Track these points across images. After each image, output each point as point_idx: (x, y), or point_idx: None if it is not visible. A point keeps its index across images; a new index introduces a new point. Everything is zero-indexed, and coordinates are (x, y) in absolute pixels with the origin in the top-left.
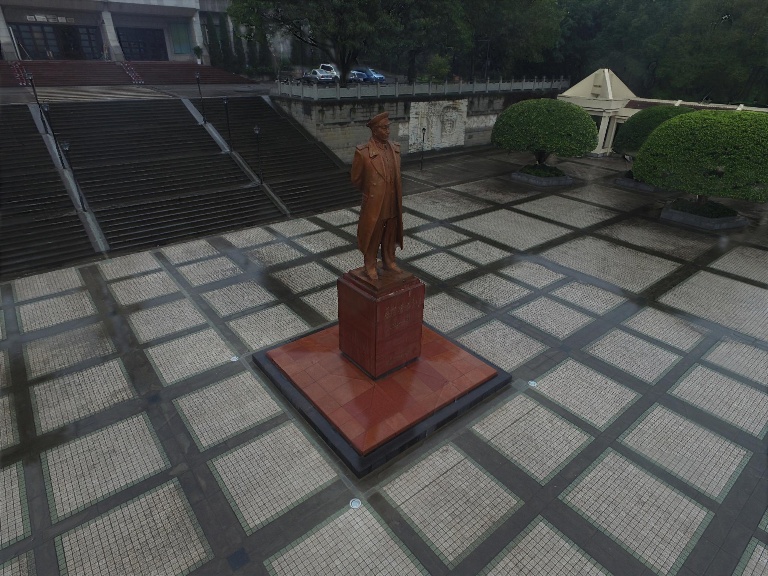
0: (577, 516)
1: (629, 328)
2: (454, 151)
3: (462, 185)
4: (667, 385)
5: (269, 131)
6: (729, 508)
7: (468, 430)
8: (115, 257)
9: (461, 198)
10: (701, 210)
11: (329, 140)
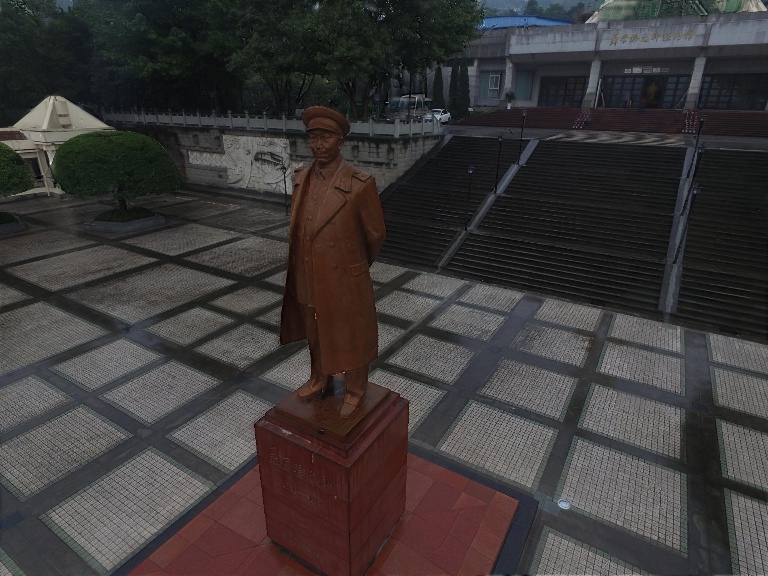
0: None
1: None
2: None
3: None
4: None
5: None
6: None
7: None
8: (440, 274)
9: None
10: None
11: None
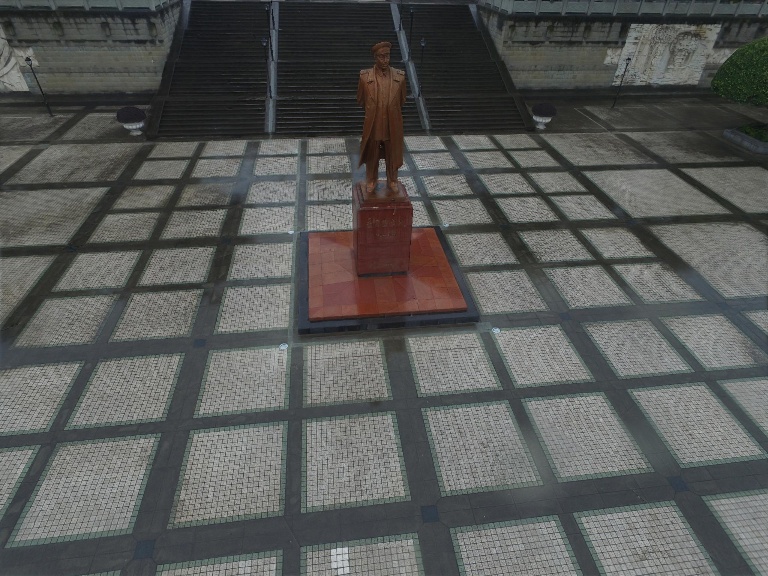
0: (422, 426)
1: (664, 325)
2: (678, 91)
3: (644, 133)
4: (636, 385)
5: (457, 44)
6: (563, 489)
7: (403, 339)
8: (275, 139)
9: (625, 147)
10: None
11: (515, 60)
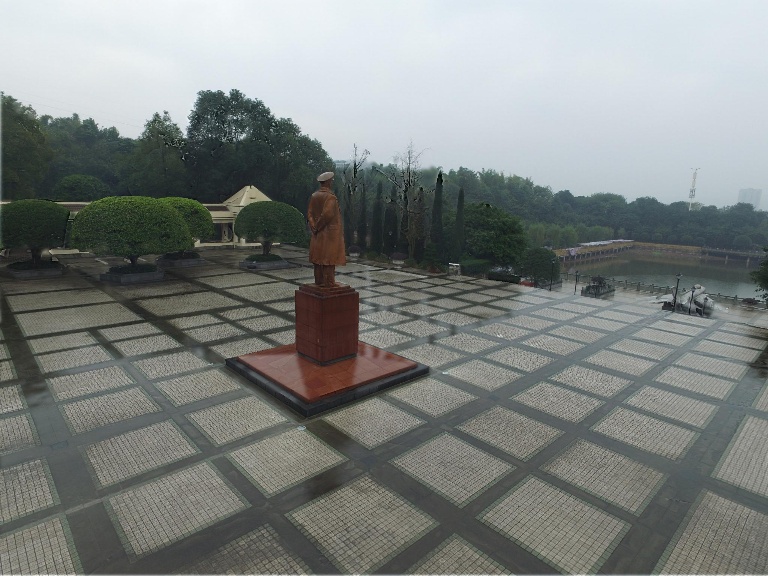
0: None
1: None
2: None
3: None
4: None
5: None
6: None
7: None
8: None
9: None
10: (145, 268)
11: None
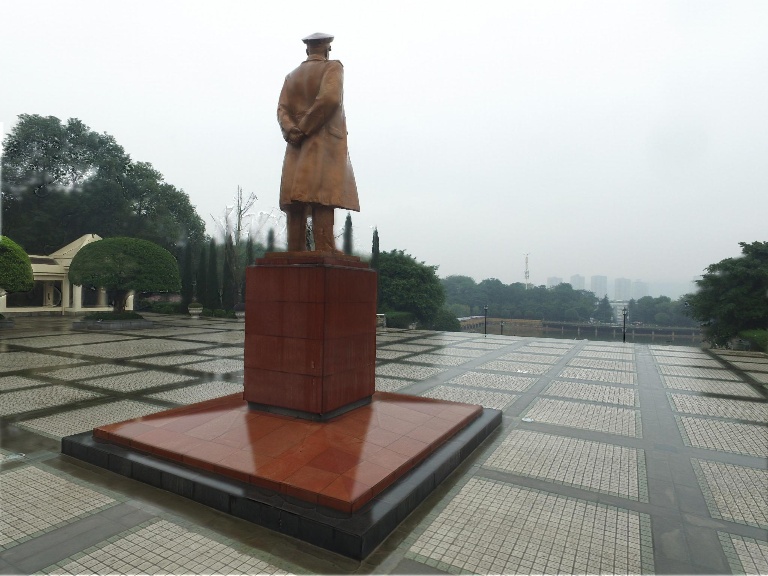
0: (432, 377)
1: None
2: None
3: None
4: None
5: None
6: None
7: None
8: None
9: None
10: None
11: None
